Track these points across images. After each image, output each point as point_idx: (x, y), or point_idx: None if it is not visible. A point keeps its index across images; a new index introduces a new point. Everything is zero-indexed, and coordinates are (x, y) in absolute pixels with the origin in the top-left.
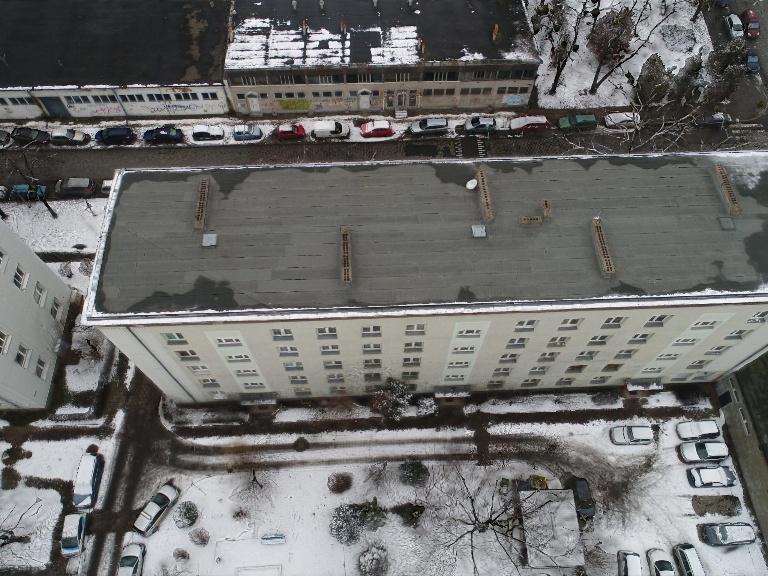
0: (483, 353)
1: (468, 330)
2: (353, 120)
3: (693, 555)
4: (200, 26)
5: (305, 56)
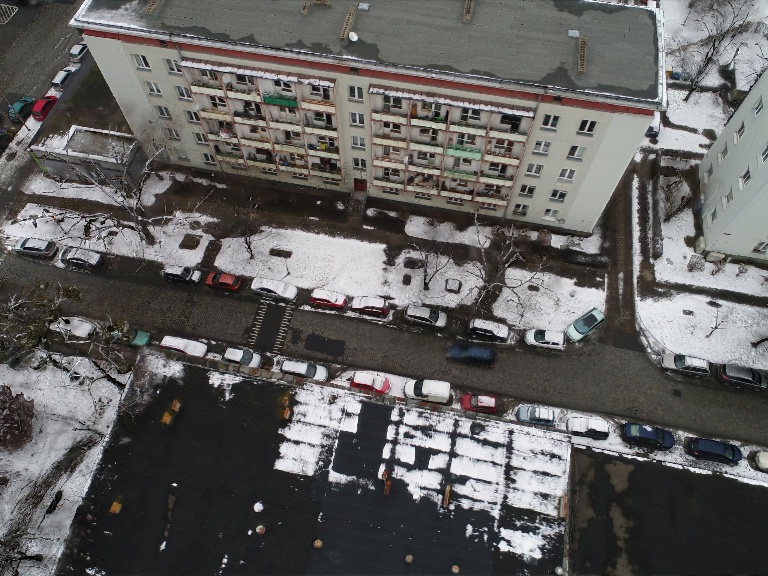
0: None
1: None
2: None
3: None
4: None
5: (453, 437)
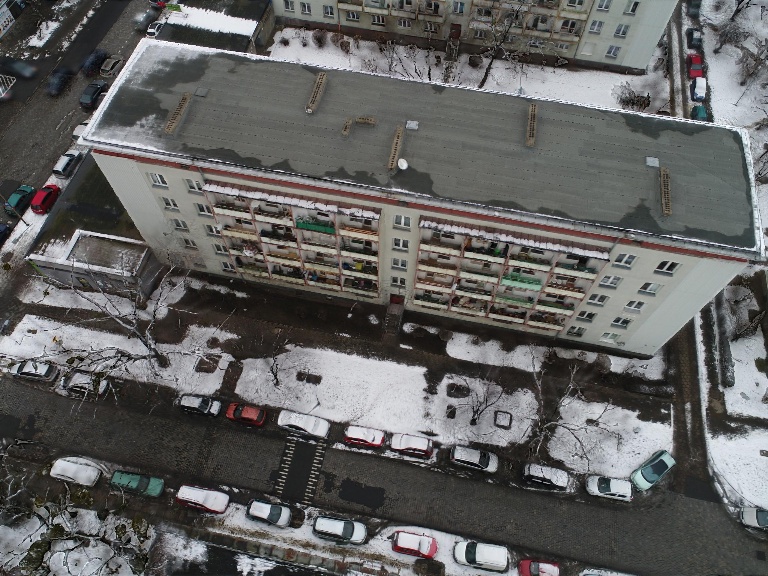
0: None
1: None
2: None
3: None
4: None
5: None
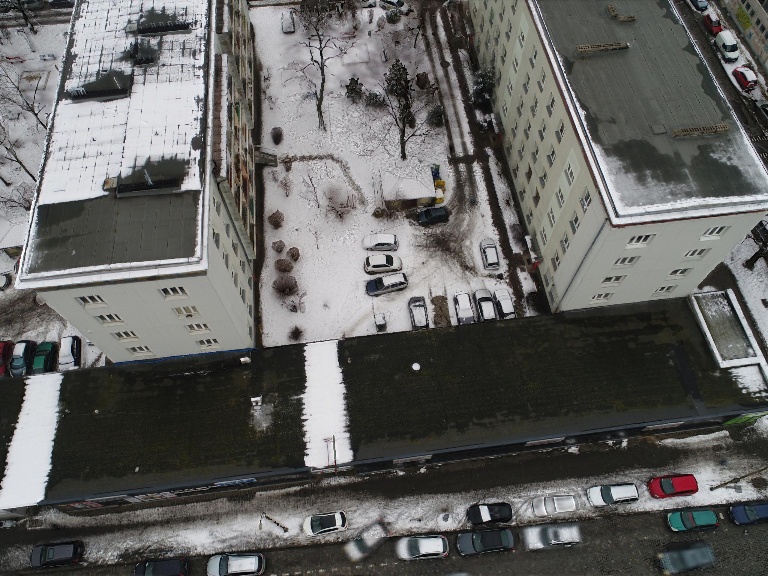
0: None
1: None
2: (749, 63)
3: (399, 278)
4: None
5: None
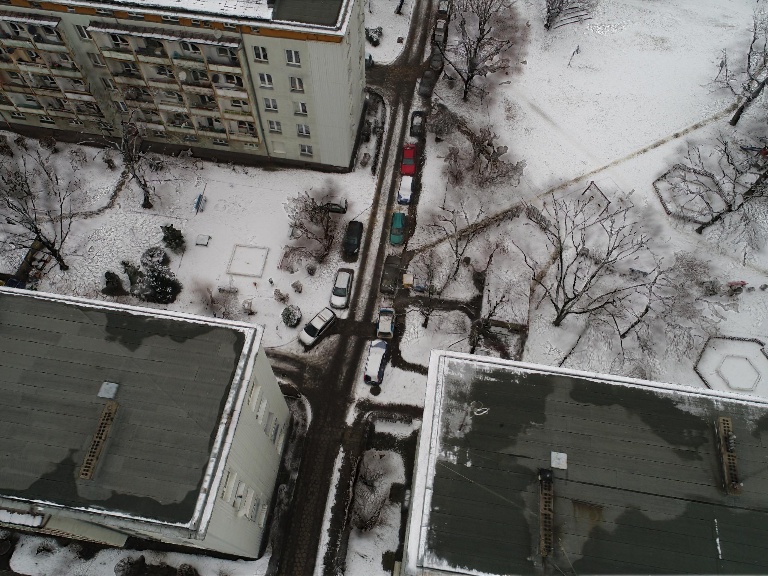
0: None
1: None
2: None
3: None
4: None
5: None
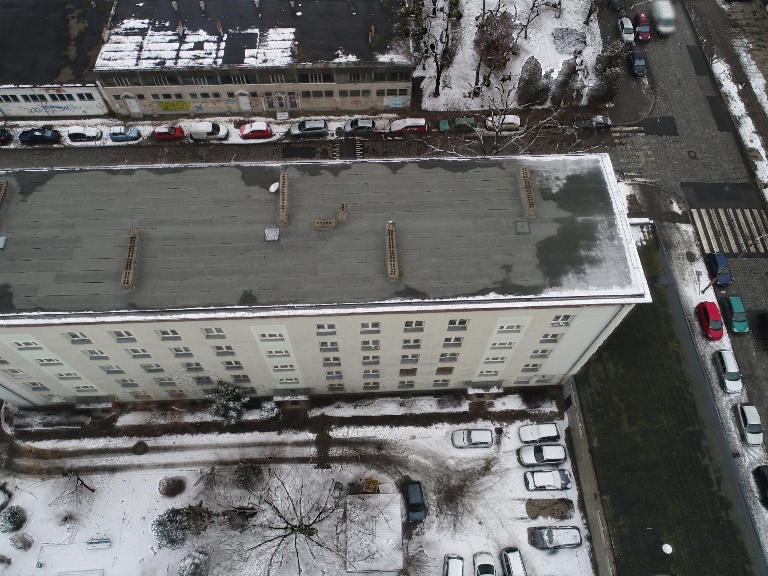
0: (300, 356)
1: (268, 334)
2: (234, 122)
3: (516, 559)
4: (80, 26)
5: (178, 57)
